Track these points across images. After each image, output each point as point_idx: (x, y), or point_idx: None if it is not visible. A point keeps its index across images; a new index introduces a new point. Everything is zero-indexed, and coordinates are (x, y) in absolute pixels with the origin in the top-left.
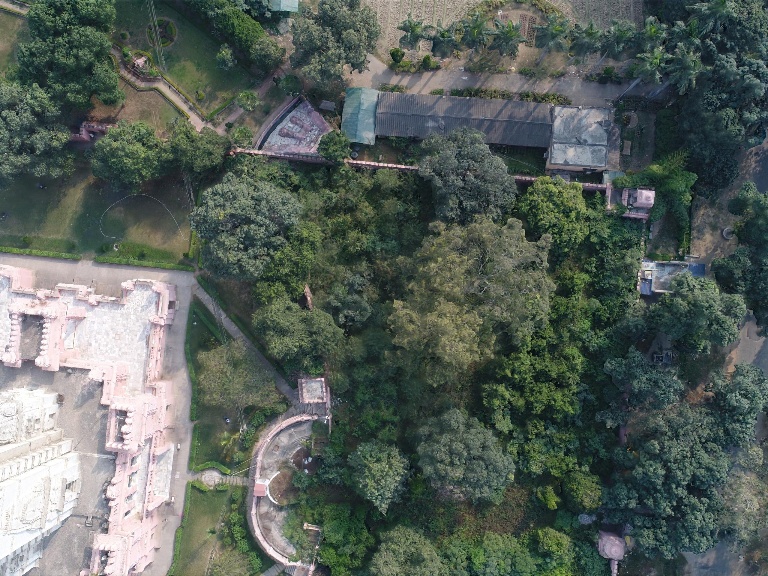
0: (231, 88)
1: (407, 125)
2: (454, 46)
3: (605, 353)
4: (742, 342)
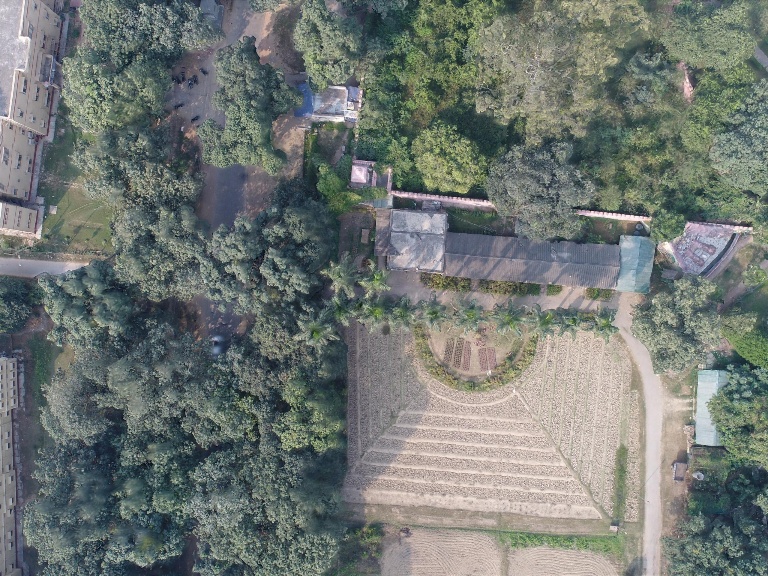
0: (764, 298)
1: (589, 254)
2: (560, 313)
3: (395, 29)
4: (258, 45)
